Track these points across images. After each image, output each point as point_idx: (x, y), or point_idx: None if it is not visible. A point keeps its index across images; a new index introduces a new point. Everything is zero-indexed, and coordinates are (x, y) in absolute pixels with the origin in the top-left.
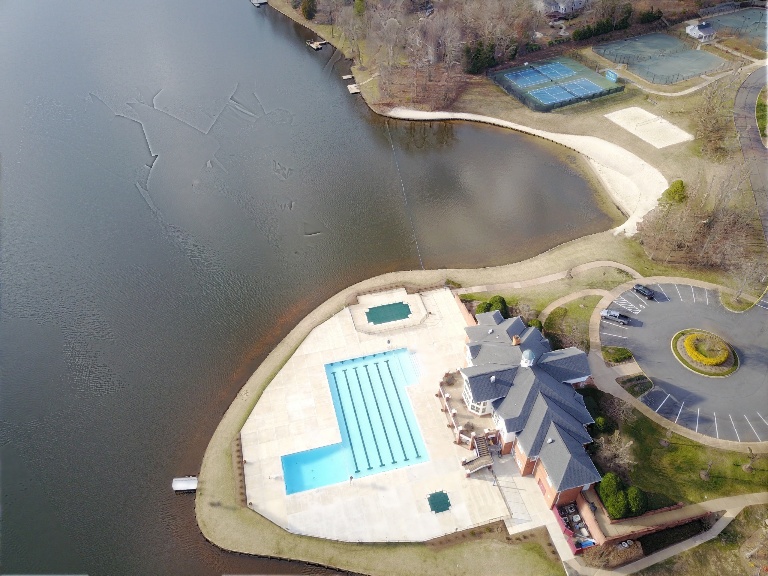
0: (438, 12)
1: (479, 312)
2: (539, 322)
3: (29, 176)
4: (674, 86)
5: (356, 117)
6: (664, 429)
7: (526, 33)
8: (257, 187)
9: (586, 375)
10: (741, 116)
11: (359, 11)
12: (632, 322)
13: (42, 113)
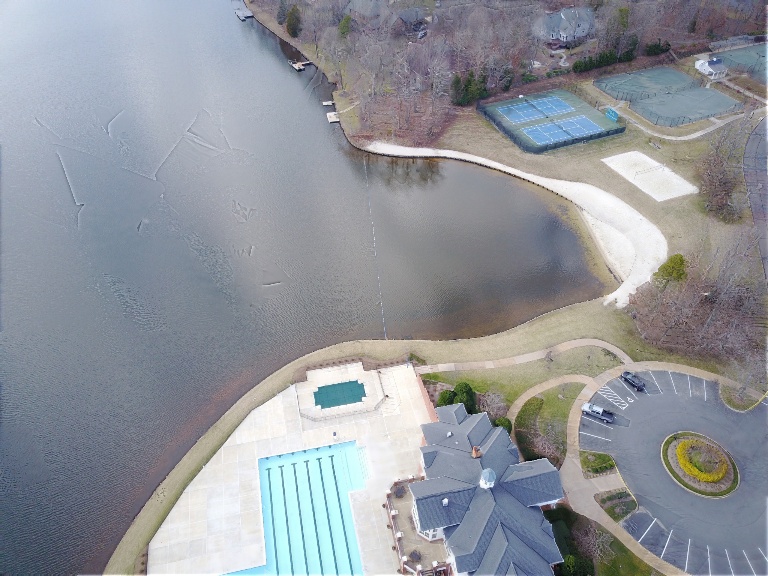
0: None
1: (441, 402)
2: (508, 422)
3: None
4: (679, 129)
5: (333, 149)
6: (647, 567)
7: (522, 63)
8: (211, 231)
9: (557, 498)
10: (751, 168)
11: (344, 33)
12: (617, 420)
13: None
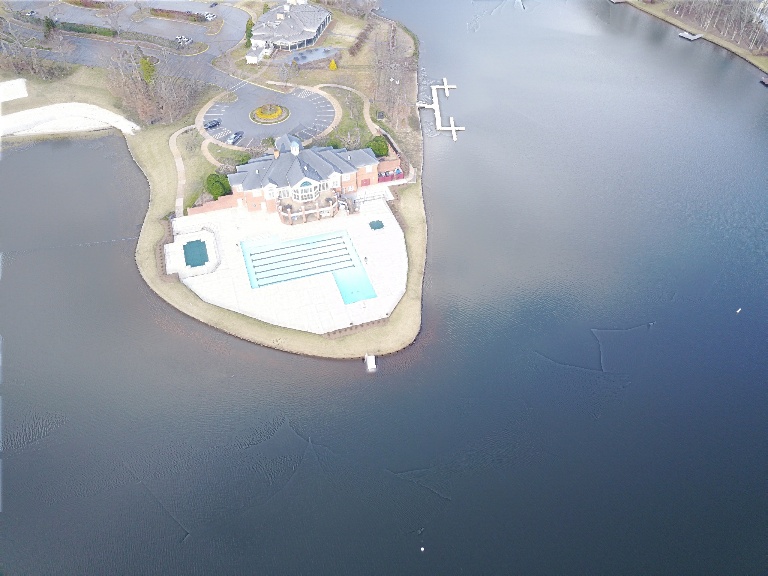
0: None
1: (220, 191)
2: None
3: None
4: None
5: None
6: (327, 135)
7: None
8: None
9: None
10: None
11: None
12: None
13: None
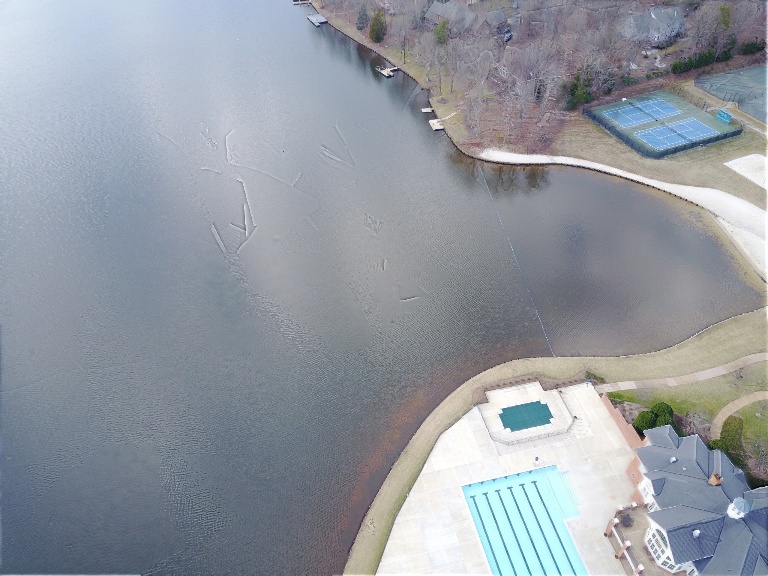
0: (533, 43)
1: (642, 423)
2: (725, 444)
3: (116, 254)
4: None
5: (441, 157)
6: None
7: (623, 65)
8: (349, 246)
9: None
10: None
11: (440, 38)
12: None
13: (127, 173)
